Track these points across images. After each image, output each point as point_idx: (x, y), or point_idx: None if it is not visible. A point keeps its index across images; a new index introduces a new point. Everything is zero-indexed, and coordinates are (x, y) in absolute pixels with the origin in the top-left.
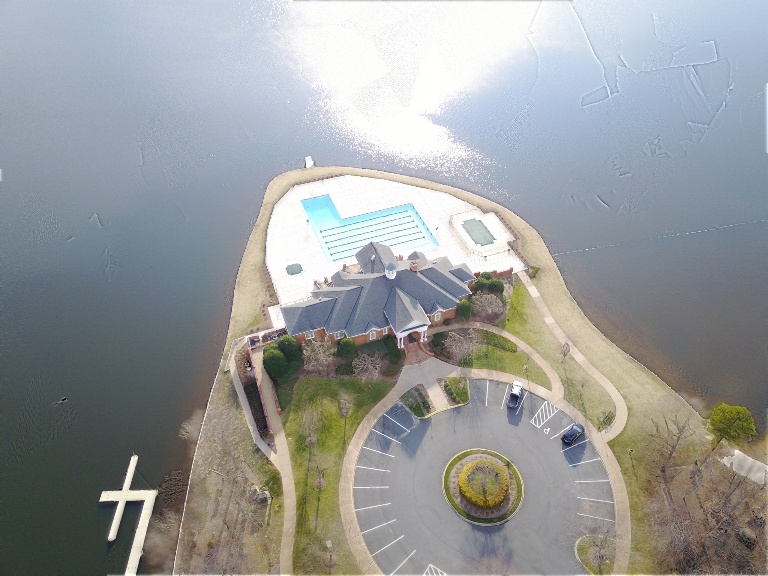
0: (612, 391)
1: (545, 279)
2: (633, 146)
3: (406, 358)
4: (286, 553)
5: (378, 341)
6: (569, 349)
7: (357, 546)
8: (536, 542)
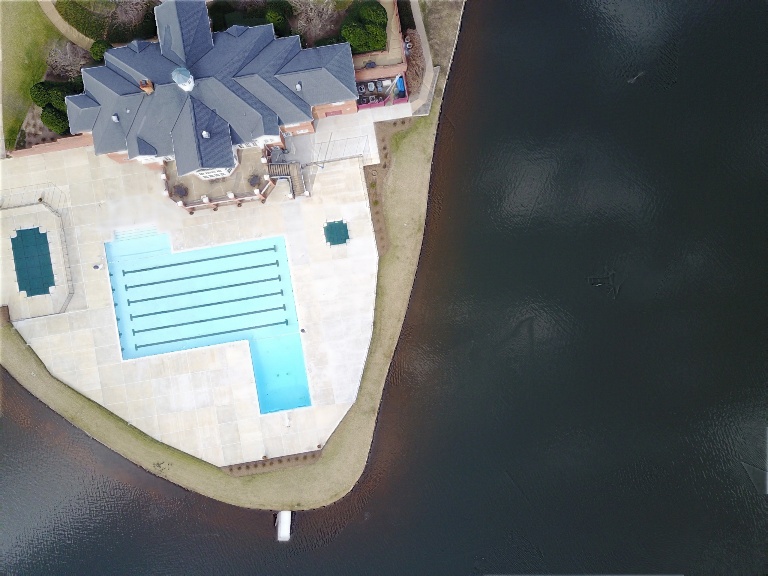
0: None
1: None
2: None
3: None
4: None
5: None
6: None
7: None
8: None
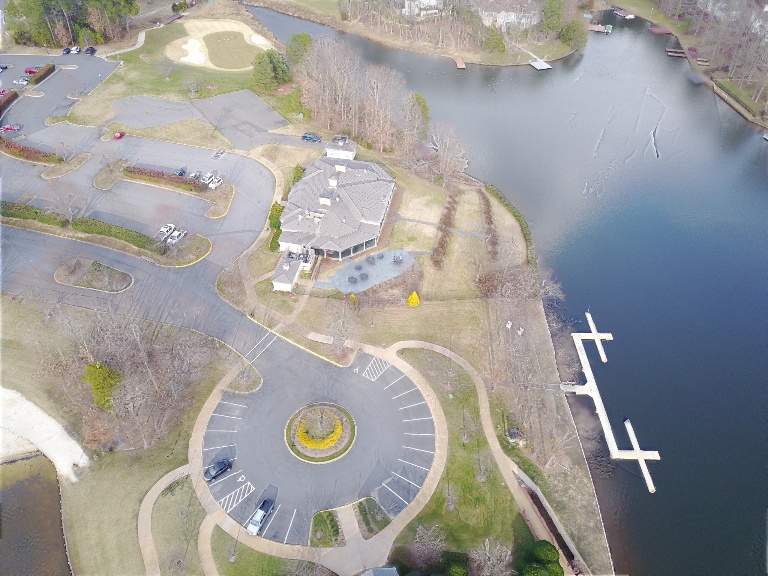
0: (145, 525)
1: None
2: None
3: None
4: (483, 396)
5: None
6: None
7: (429, 393)
8: (290, 390)
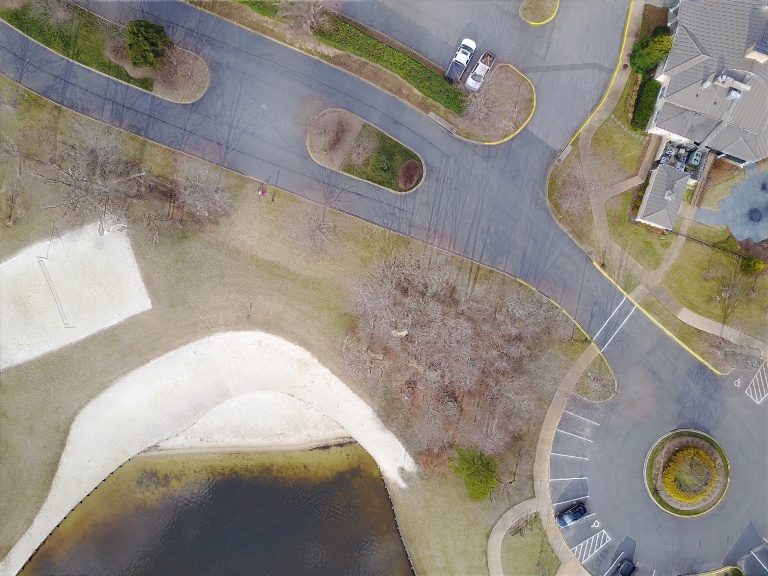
0: (496, 564)
1: None
2: None
3: None
4: None
5: None
6: None
7: None
8: (651, 405)
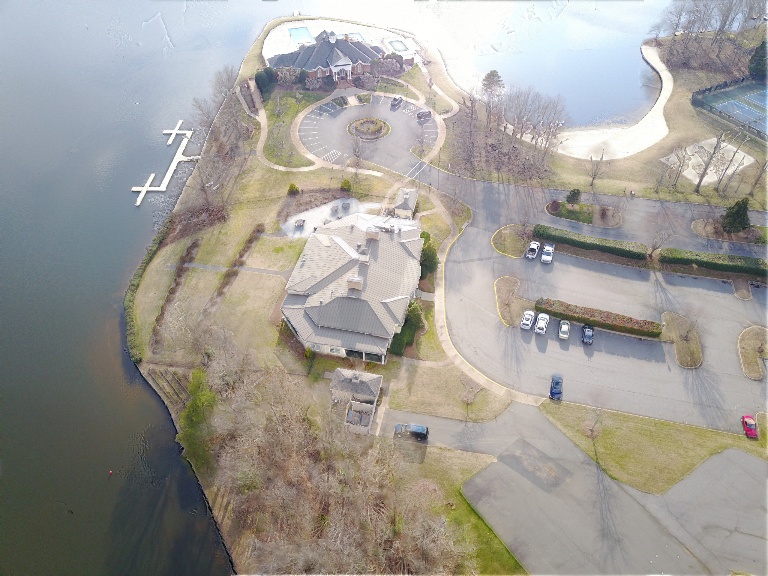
0: (454, 104)
1: (434, 66)
2: (517, 13)
3: (338, 85)
4: (260, 146)
5: (323, 77)
6: (432, 83)
7: (297, 143)
8: (391, 146)
